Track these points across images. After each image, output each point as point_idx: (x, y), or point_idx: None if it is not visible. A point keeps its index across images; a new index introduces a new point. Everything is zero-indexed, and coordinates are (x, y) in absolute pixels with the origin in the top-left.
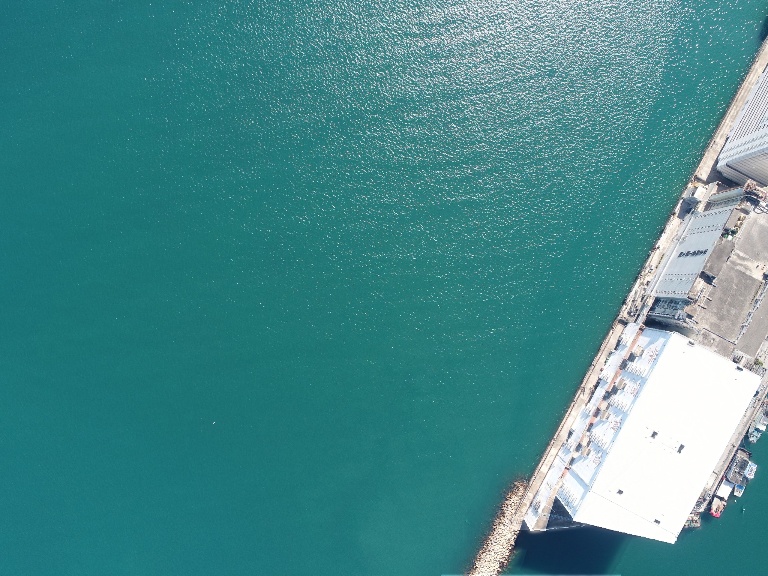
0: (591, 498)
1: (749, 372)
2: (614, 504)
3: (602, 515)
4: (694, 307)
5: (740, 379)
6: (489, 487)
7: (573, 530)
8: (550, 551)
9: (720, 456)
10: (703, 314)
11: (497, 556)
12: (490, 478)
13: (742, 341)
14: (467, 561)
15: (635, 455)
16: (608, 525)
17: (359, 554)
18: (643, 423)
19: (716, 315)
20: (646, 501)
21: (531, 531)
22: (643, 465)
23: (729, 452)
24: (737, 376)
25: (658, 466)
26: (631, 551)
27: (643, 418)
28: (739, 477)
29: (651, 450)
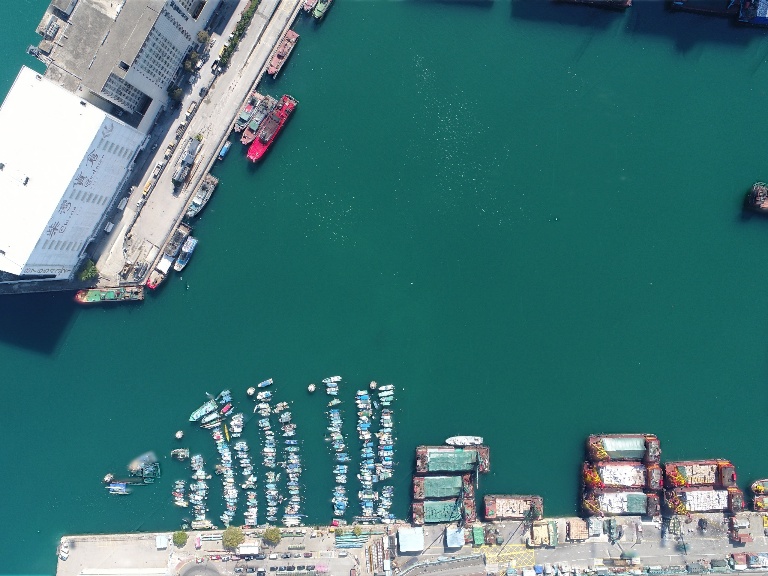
0: None
1: (94, 108)
2: None
3: None
4: (46, 42)
5: (85, 114)
6: None
7: (22, 298)
8: (1, 318)
9: (64, 190)
10: (59, 52)
11: None
12: None
13: (88, 76)
14: None
15: None
16: None
17: None
18: None
19: (72, 53)
20: None
21: None
22: None
23: (171, 227)
24: (82, 111)
25: (5, 197)
26: (81, 323)
27: None
28: (172, 249)
29: None
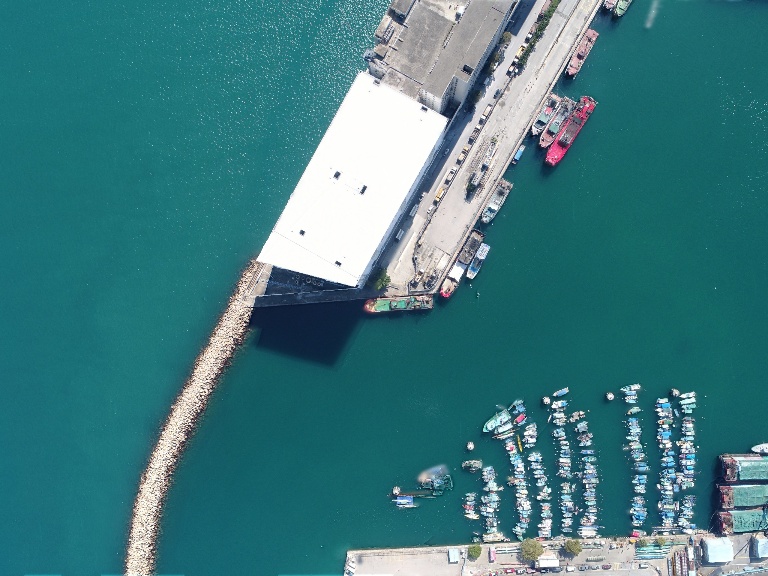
0: (274, 239)
1: (435, 113)
2: (297, 245)
3: (285, 256)
4: (383, 46)
5: (426, 120)
6: (228, 266)
7: (306, 308)
8: (283, 329)
9: (403, 199)
10: (394, 56)
11: (229, 331)
12: (227, 256)
13: (428, 81)
14: (204, 338)
15: (318, 195)
16: (290, 266)
17: (97, 326)
18: (327, 163)
19: (407, 57)
20: (330, 244)
21: (266, 309)
22: (325, 205)
23: (463, 233)
24: (423, 117)
25: (340, 207)
26: (365, 333)
27: (327, 158)
28: (468, 256)
29: (334, 191)
